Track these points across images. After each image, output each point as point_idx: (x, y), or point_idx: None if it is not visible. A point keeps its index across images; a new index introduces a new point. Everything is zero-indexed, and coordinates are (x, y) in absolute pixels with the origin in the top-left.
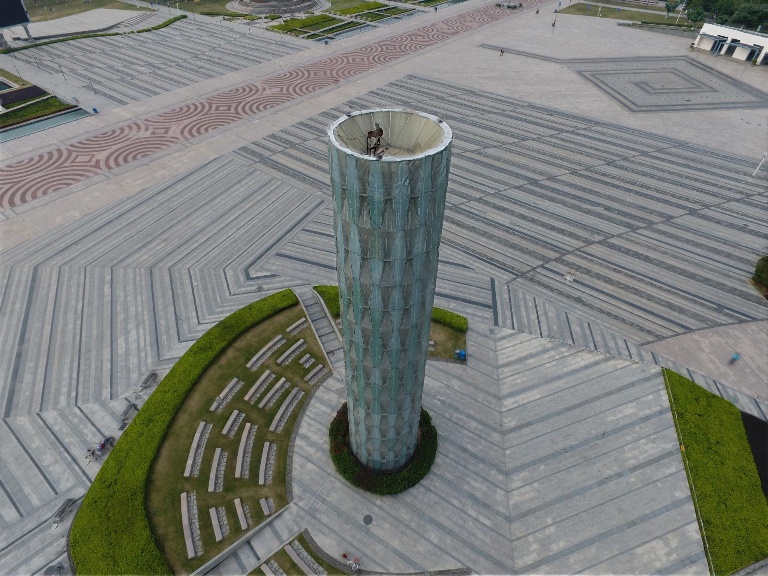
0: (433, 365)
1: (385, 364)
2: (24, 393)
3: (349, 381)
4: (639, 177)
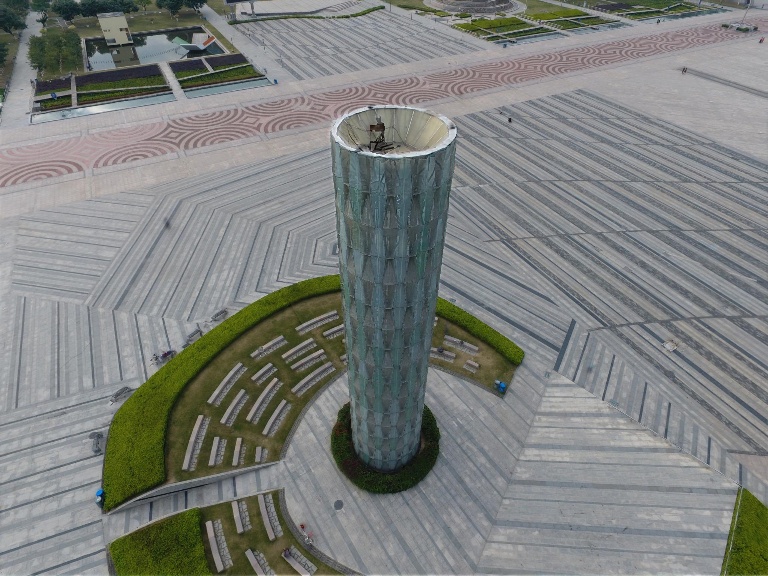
0: (468, 387)
1: (370, 359)
2: (133, 295)
3: None
4: None
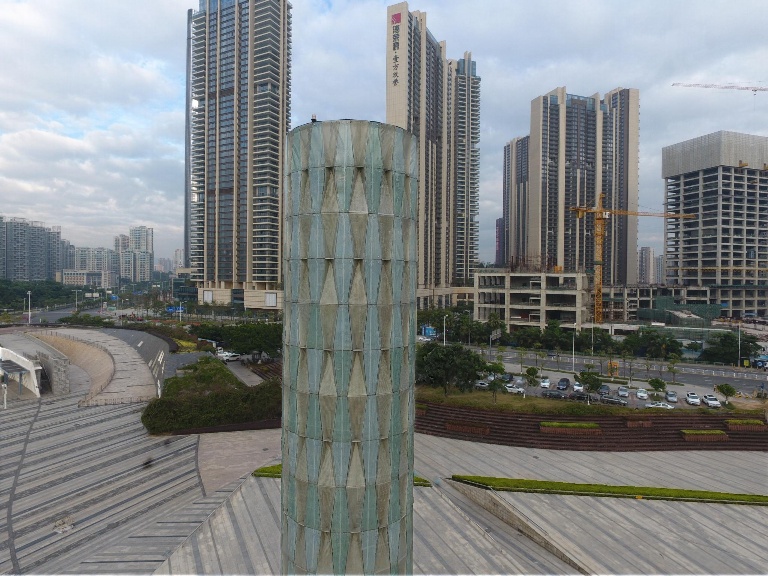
0: None
1: None
2: None
3: (391, 562)
4: None
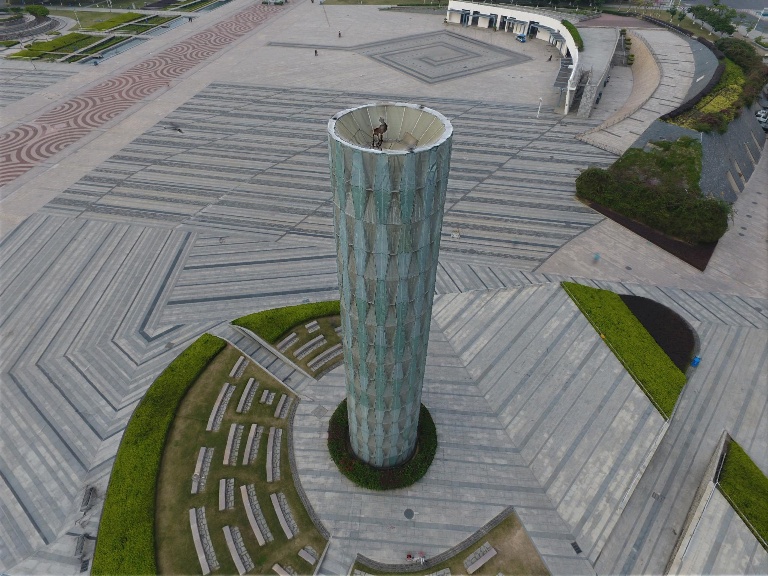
0: None
1: (406, 356)
2: None
3: (362, 389)
4: (463, 137)
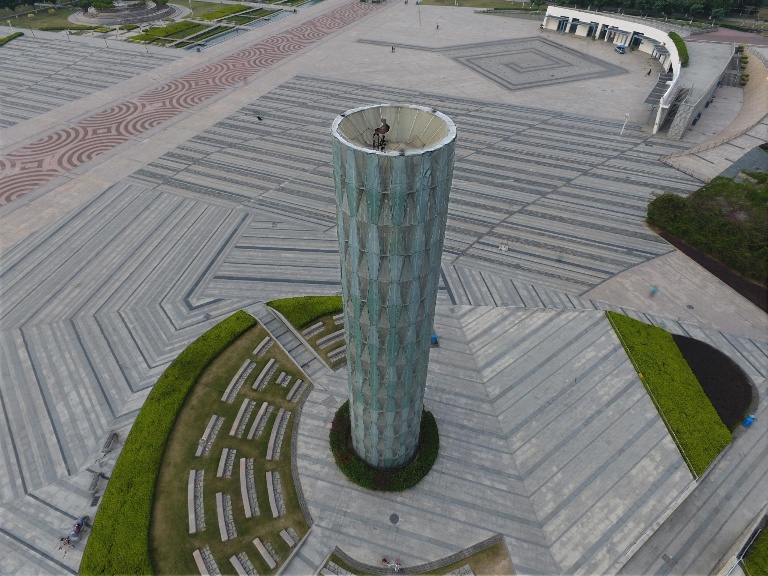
0: None
1: (400, 360)
2: None
3: (358, 386)
4: (534, 148)
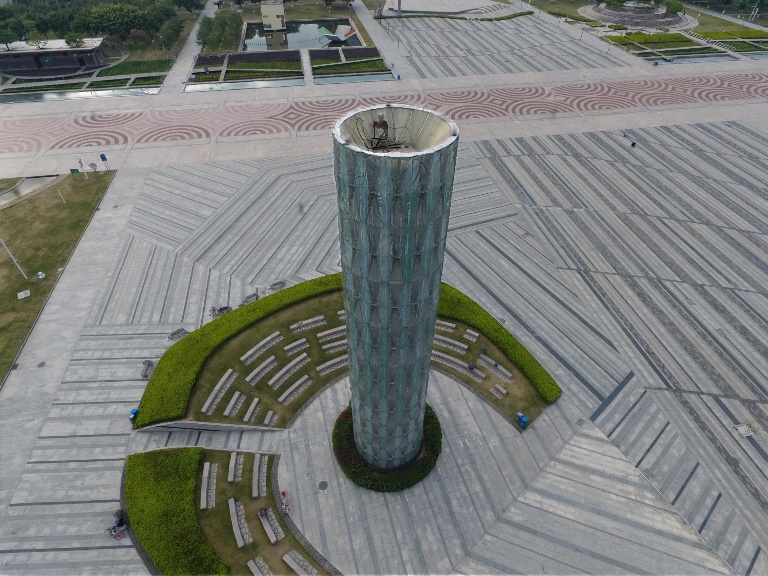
0: (488, 411)
1: (361, 352)
2: (214, 252)
3: None
4: None
